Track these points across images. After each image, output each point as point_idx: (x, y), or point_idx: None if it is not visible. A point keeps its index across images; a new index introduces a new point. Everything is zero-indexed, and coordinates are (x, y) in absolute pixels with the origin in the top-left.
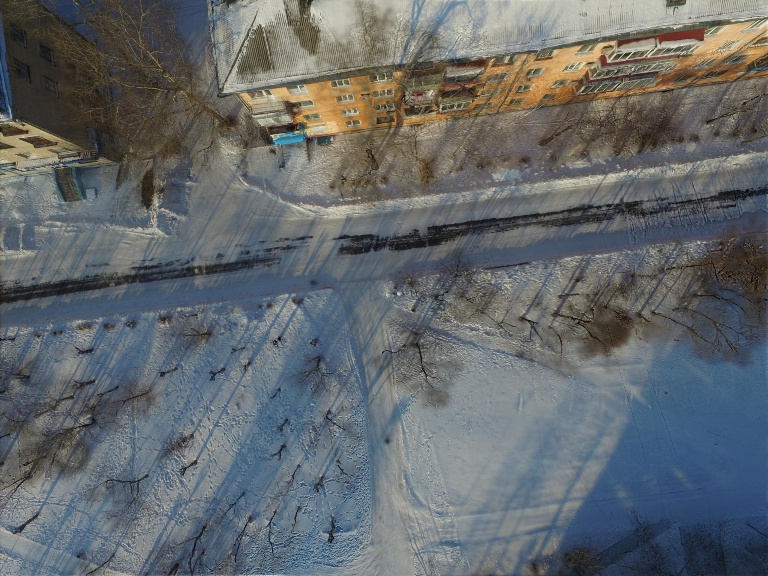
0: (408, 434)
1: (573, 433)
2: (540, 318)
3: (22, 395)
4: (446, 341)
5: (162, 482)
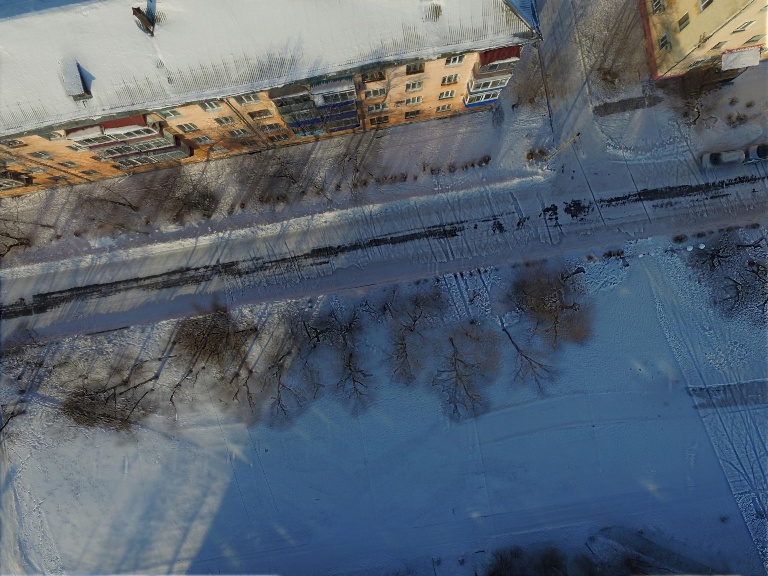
0: (20, 501)
1: (178, 494)
2: (141, 381)
3: None
4: (52, 407)
5: None
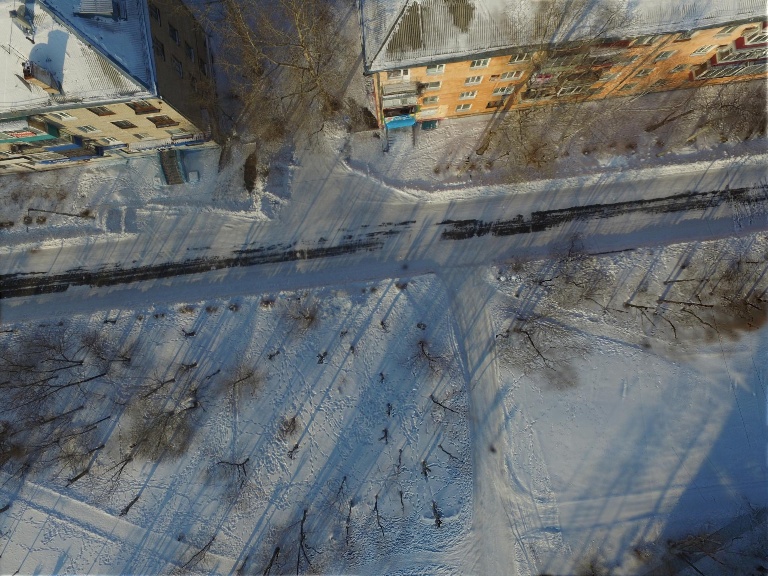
0: (510, 420)
1: (677, 420)
2: (645, 304)
3: (123, 378)
4: (550, 327)
5: (263, 466)
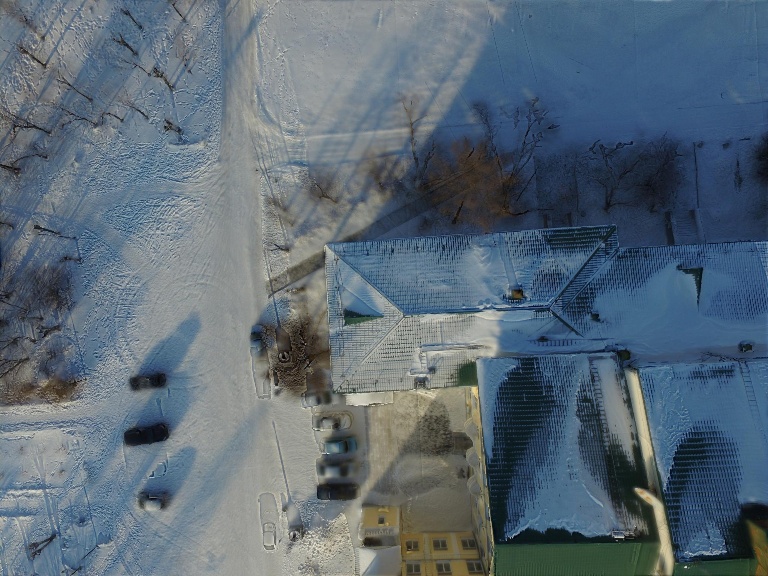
0: (263, 48)
1: (431, 53)
2: None
3: None
4: None
5: (10, 86)
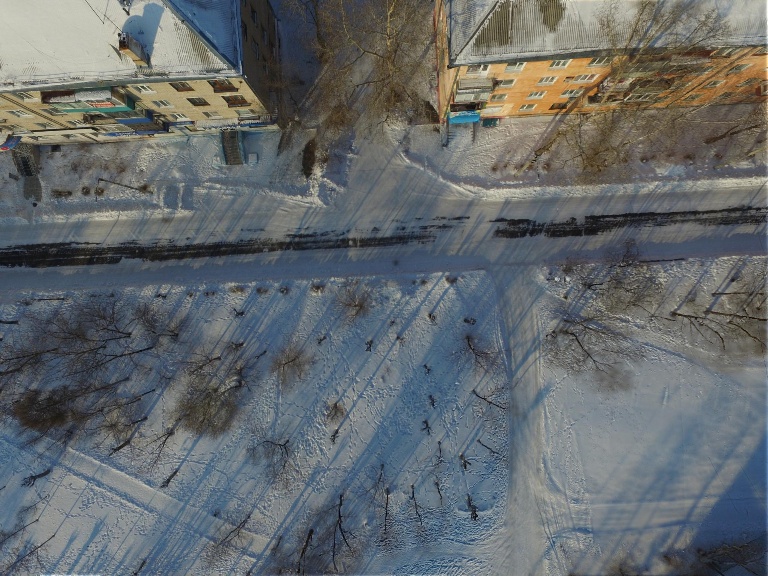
0: (550, 419)
1: (715, 431)
2: None
3: (170, 352)
4: (596, 330)
5: (302, 448)
